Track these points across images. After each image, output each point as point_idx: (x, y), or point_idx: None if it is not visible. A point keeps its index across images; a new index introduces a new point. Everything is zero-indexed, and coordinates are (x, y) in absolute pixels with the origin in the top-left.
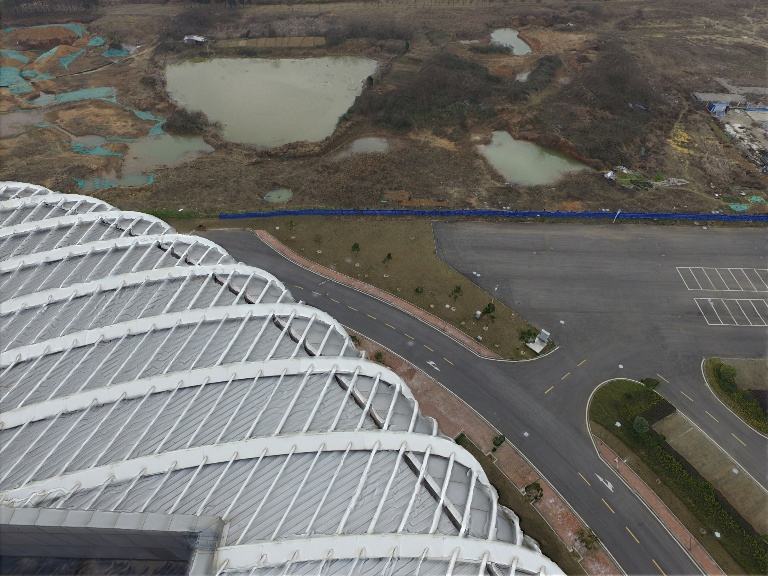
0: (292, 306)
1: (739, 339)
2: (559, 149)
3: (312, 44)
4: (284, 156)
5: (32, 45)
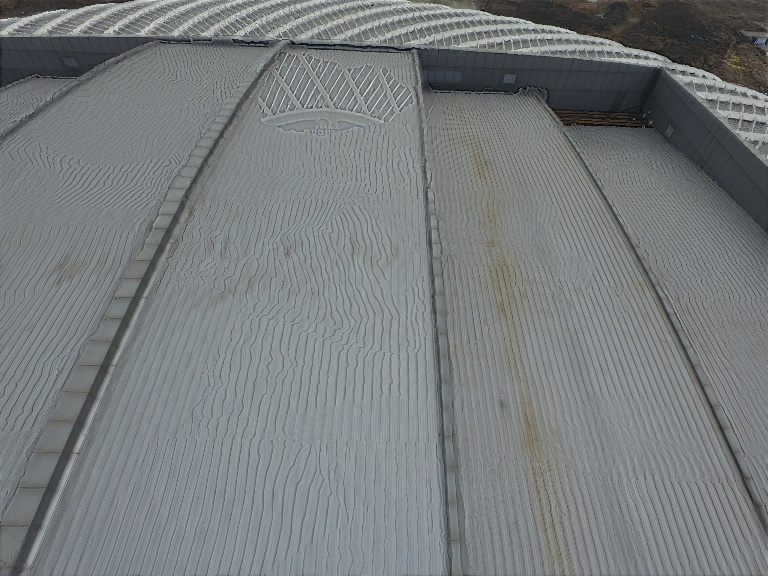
0: None
1: None
2: None
3: None
4: None
5: None
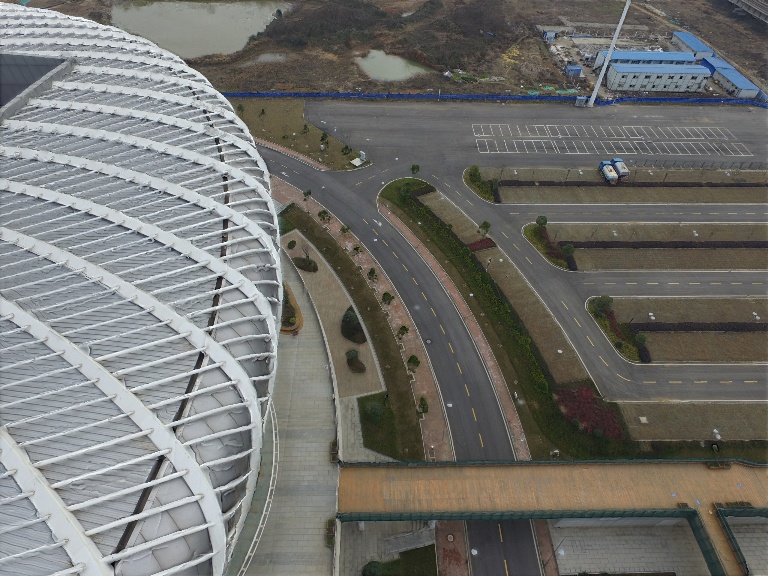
0: (136, 37)
1: (496, 159)
2: (417, 60)
3: None
4: (201, 63)
5: None
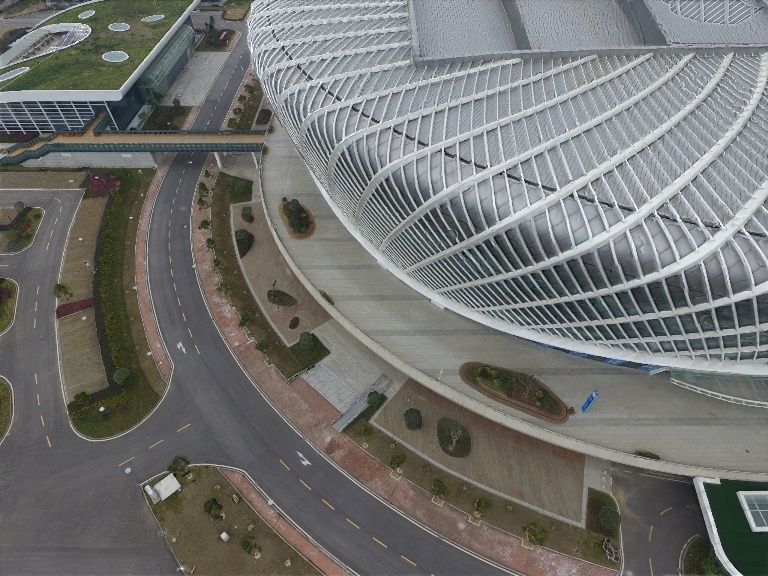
0: None
1: None
2: None
3: None
4: None
5: None
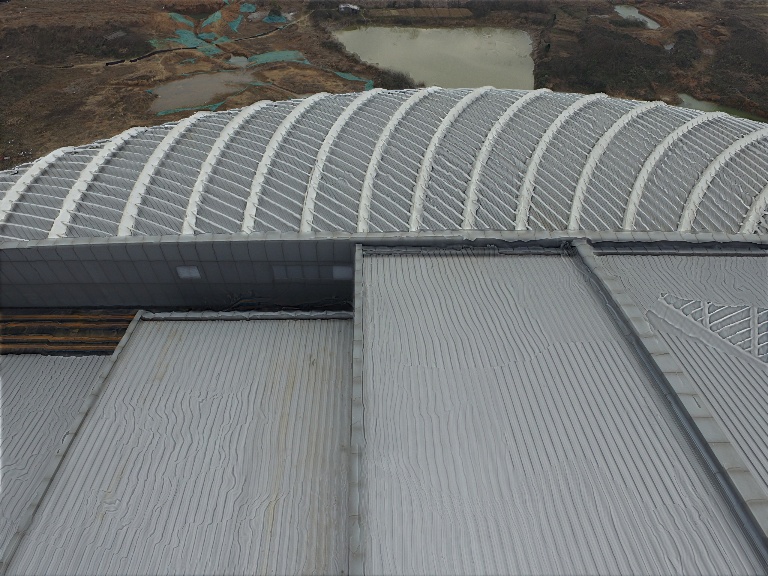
0: None
1: None
2: (744, 108)
3: (461, 15)
4: None
5: (178, 10)
